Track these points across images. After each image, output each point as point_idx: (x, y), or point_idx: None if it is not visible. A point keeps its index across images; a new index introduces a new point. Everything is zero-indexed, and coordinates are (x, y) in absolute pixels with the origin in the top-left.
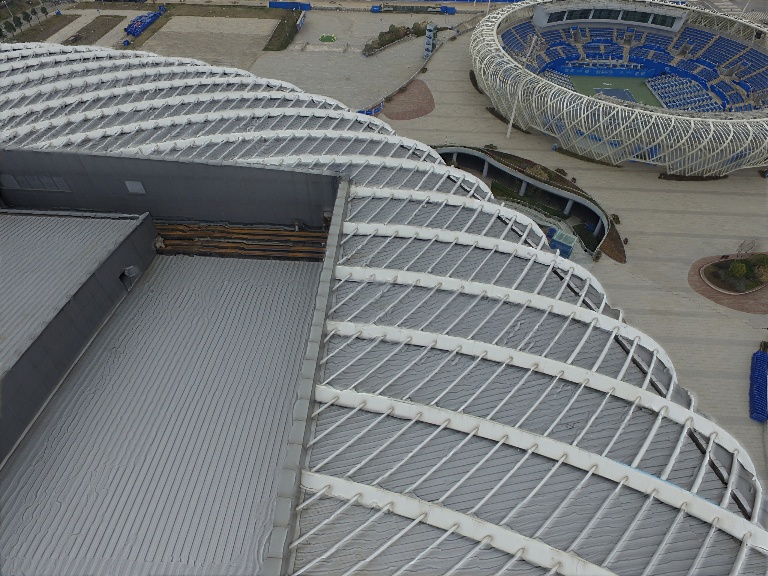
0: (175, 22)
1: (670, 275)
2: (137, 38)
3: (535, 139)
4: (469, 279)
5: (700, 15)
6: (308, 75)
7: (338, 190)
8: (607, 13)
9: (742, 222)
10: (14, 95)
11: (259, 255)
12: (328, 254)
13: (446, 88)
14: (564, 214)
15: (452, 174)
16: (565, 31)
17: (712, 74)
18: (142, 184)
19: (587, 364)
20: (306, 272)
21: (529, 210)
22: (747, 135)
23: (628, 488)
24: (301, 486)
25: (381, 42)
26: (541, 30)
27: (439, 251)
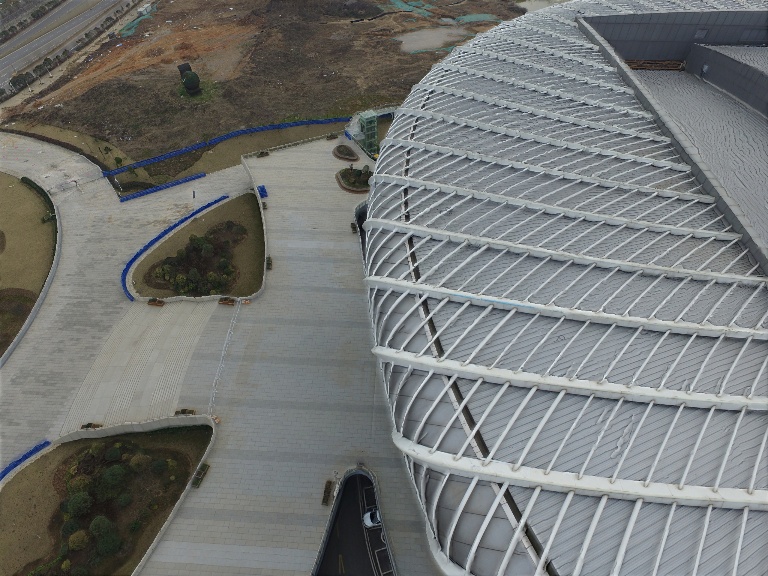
0: None
1: None
2: None
3: None
4: (711, 511)
5: None
6: None
7: None
8: None
9: None
10: None
11: None
12: None
13: None
14: None
15: None
16: None
17: None
18: None
19: (538, 400)
20: None
21: None
22: None
23: None
24: (765, 275)
25: None
26: None
27: None
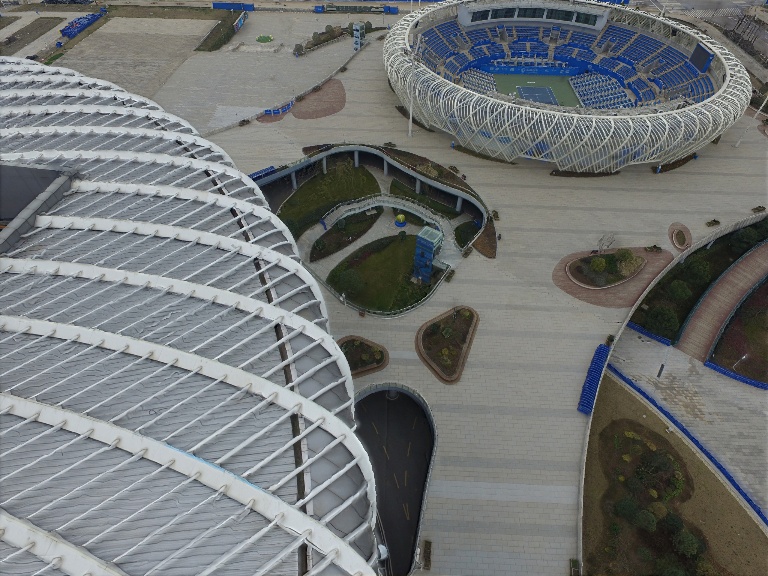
0: (112, 23)
1: (536, 270)
2: (71, 40)
3: (437, 137)
4: (139, 270)
5: (623, 13)
6: (233, 75)
7: None
8: (532, 12)
9: (622, 217)
10: None
11: None
12: None
13: (361, 87)
14: (456, 211)
15: (212, 169)
16: (491, 30)
17: (631, 72)
18: None
19: (216, 352)
20: None
21: (418, 207)
22: (627, 131)
23: (174, 471)
24: None
25: (315, 42)
26: (466, 29)
27: (130, 243)
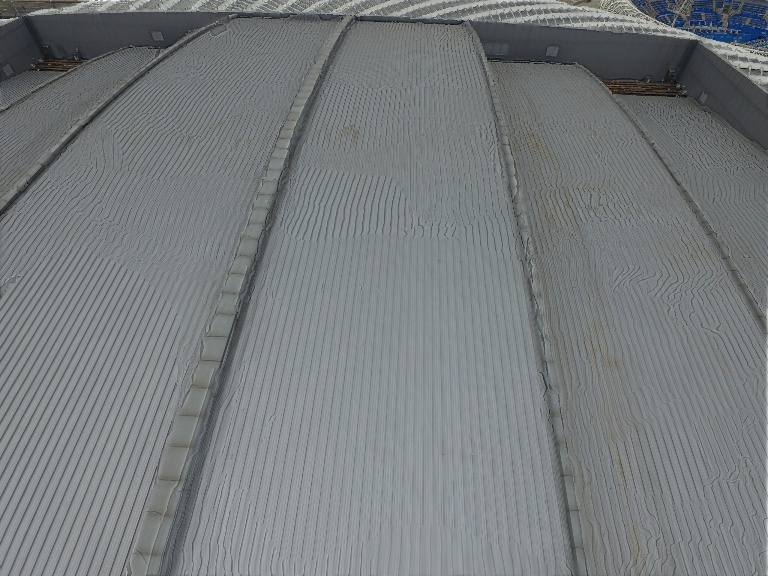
0: None
1: None
2: None
3: None
4: None
5: None
6: None
7: (703, 45)
8: None
9: None
10: (433, 2)
11: (635, 93)
12: (734, 67)
13: None
14: None
15: None
16: (670, 1)
17: None
18: (559, 49)
19: None
20: (673, 100)
21: None
22: None
23: None
24: None
25: None
26: (650, 0)
27: None
